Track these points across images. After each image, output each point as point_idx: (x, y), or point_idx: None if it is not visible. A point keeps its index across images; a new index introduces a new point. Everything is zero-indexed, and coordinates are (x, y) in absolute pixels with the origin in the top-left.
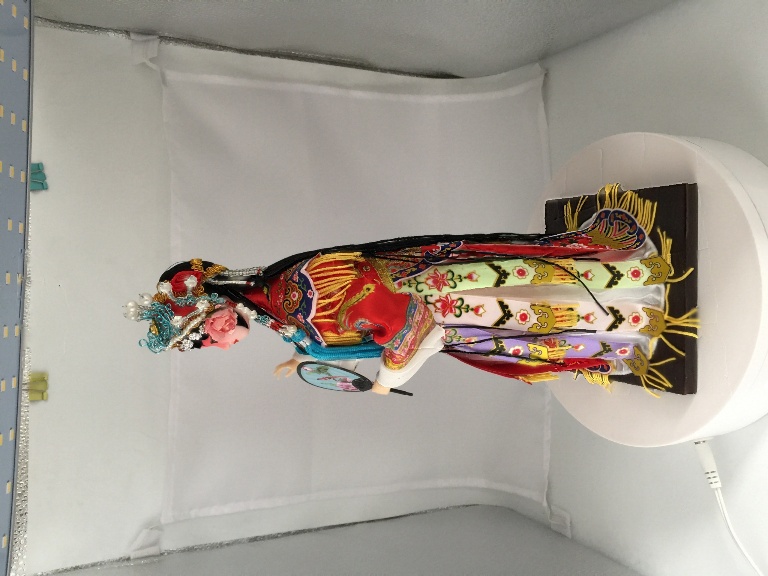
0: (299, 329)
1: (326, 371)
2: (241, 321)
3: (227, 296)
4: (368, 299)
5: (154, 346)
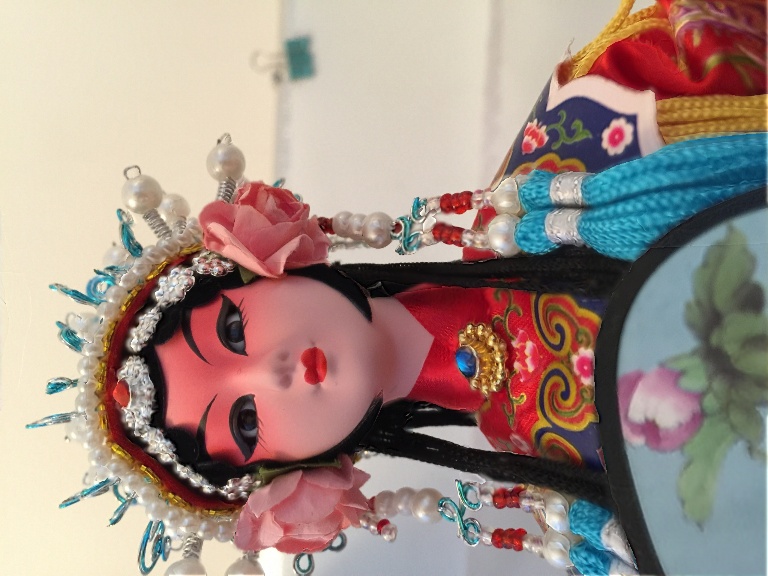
0: None
1: None
2: (347, 286)
3: None
4: None
5: None
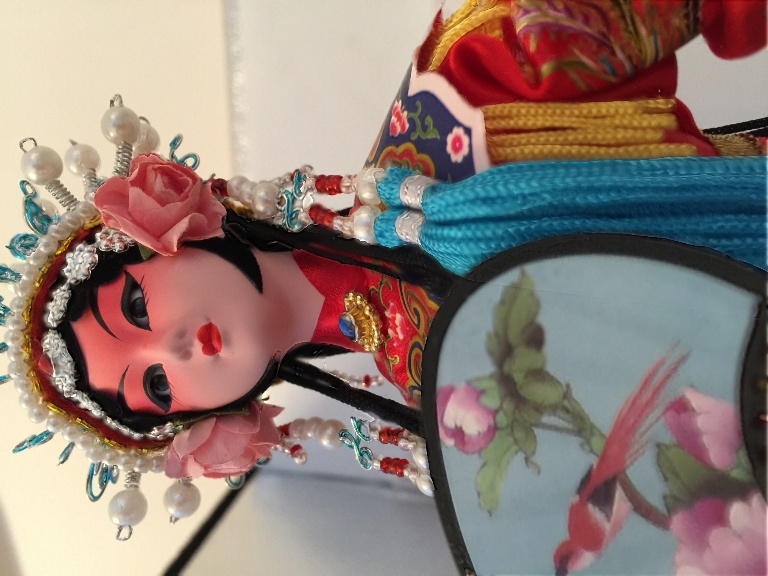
0: None
1: (545, 372)
2: (241, 255)
3: None
4: None
5: None
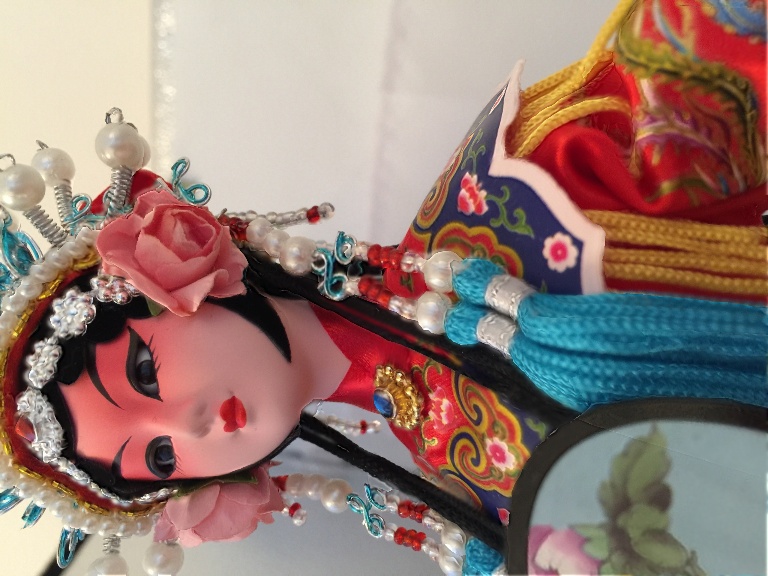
0: None
1: (667, 534)
2: (264, 315)
3: None
4: None
5: None
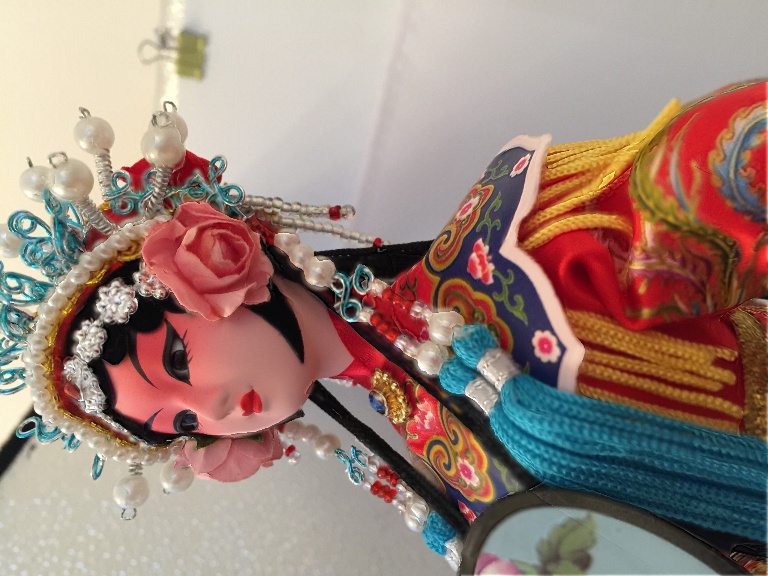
0: (472, 324)
1: None
2: (284, 317)
3: (267, 250)
4: (761, 84)
5: (2, 355)
